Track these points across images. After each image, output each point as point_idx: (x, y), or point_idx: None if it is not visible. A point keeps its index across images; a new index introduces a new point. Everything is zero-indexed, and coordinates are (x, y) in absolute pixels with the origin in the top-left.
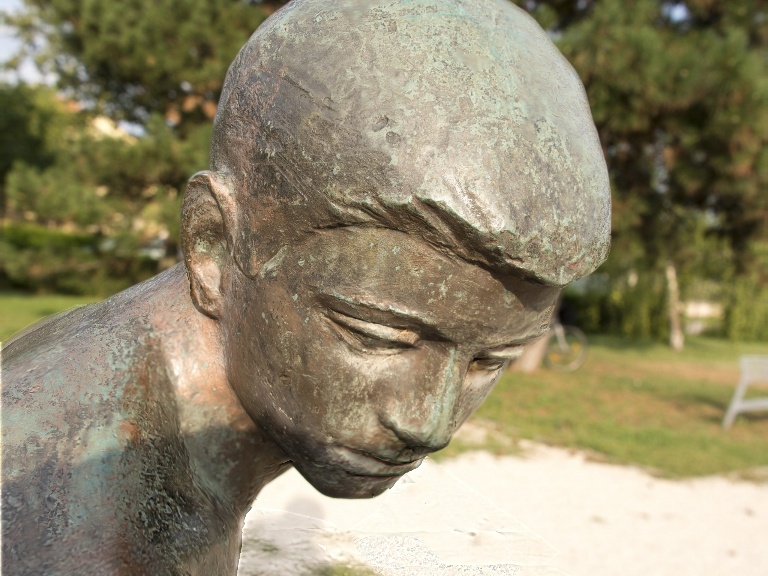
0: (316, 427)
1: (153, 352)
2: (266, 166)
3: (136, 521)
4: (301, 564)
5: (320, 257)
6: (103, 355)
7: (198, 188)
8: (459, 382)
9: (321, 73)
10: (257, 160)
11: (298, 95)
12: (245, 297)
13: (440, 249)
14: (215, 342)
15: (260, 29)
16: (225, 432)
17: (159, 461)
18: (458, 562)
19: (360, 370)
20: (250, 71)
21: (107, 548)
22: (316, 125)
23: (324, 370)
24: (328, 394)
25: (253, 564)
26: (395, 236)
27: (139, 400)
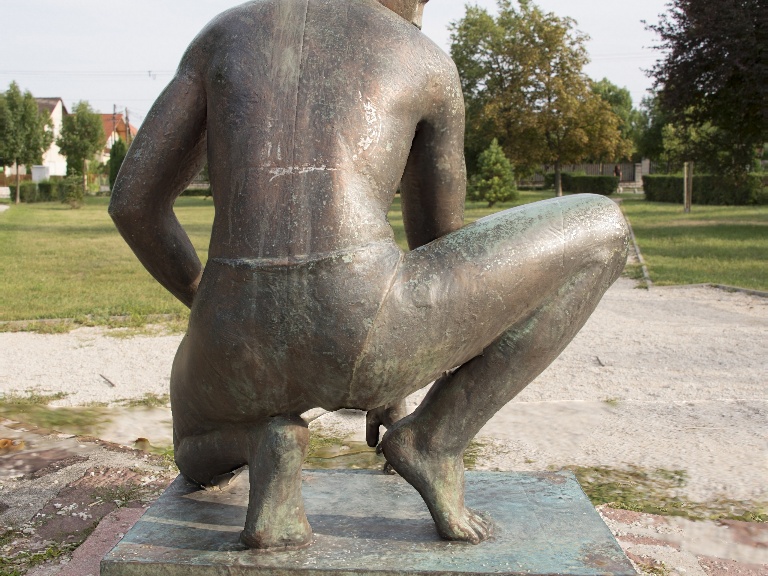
0: None
1: None
2: None
3: None
4: None
5: None
6: (376, 1)
7: None
8: None
9: None
10: None
11: None
12: None
13: None
14: None
15: None
16: None
17: None
18: None
19: None
20: None
21: None
22: None
23: None
24: None
25: None
26: None
27: None
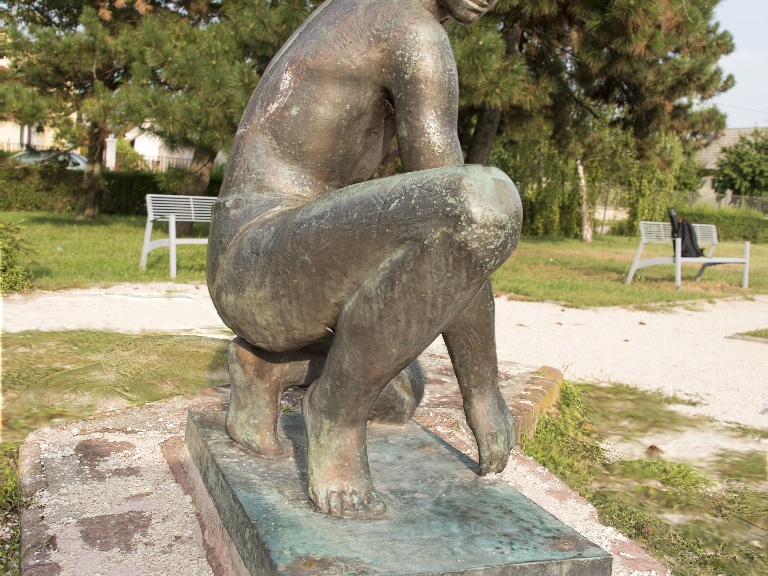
0: None
1: None
2: None
3: None
4: None
5: None
6: None
7: None
8: None
9: None
10: None
11: None
12: None
13: None
14: None
15: None
16: (428, 4)
17: None
18: None
19: None
20: None
21: None
22: None
23: None
24: None
25: None
26: None
27: None
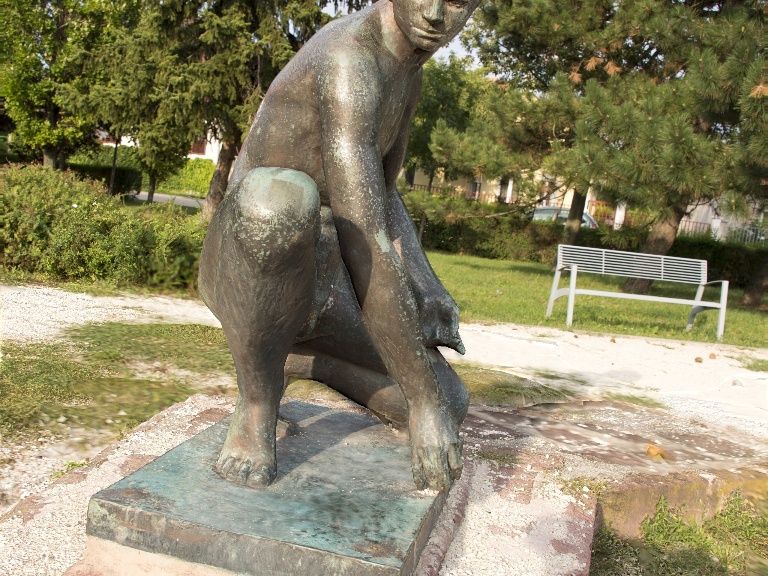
0: (408, 21)
1: (377, 12)
2: None
3: (360, 35)
4: (606, 394)
5: None
6: None
7: None
8: (439, 3)
9: None
10: None
11: None
12: None
13: None
14: (392, 9)
15: None
16: (394, 34)
17: (370, 30)
18: (743, 418)
19: (416, 2)
20: None
21: (352, 35)
22: None
23: (408, 2)
24: (409, 9)
25: (570, 387)
26: None
27: (369, 18)
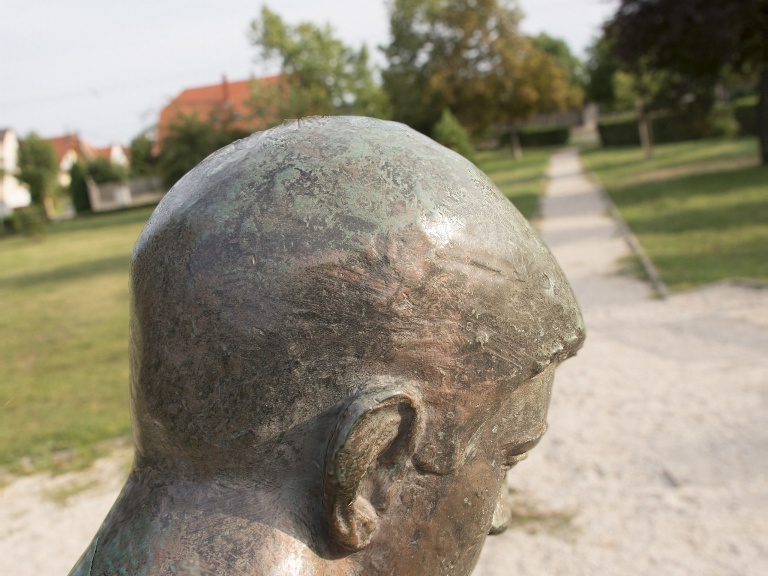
0: None
1: None
2: (479, 354)
3: None
4: None
5: (511, 415)
6: None
7: (380, 413)
8: None
9: (498, 250)
10: (464, 352)
11: (491, 276)
12: (434, 497)
13: (558, 363)
14: None
15: (394, 216)
16: None
17: None
18: None
19: None
20: (425, 265)
21: None
22: (517, 299)
23: None
24: None
25: None
26: (549, 368)
27: None
